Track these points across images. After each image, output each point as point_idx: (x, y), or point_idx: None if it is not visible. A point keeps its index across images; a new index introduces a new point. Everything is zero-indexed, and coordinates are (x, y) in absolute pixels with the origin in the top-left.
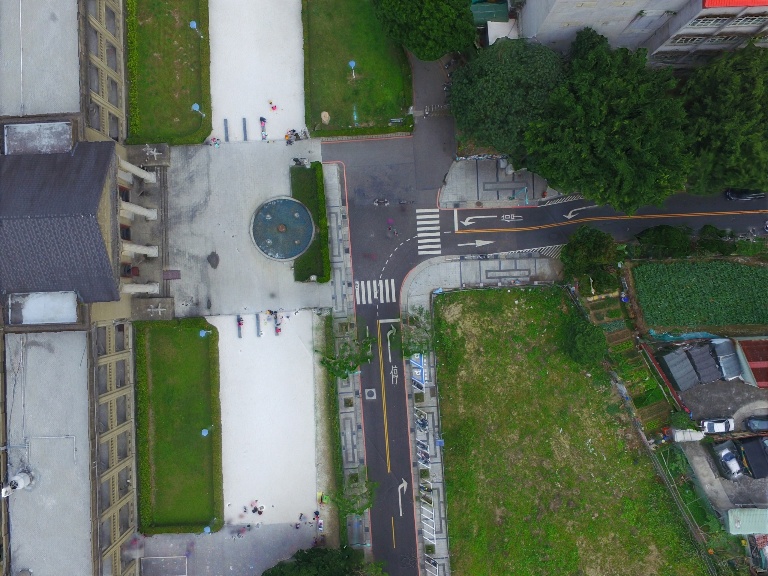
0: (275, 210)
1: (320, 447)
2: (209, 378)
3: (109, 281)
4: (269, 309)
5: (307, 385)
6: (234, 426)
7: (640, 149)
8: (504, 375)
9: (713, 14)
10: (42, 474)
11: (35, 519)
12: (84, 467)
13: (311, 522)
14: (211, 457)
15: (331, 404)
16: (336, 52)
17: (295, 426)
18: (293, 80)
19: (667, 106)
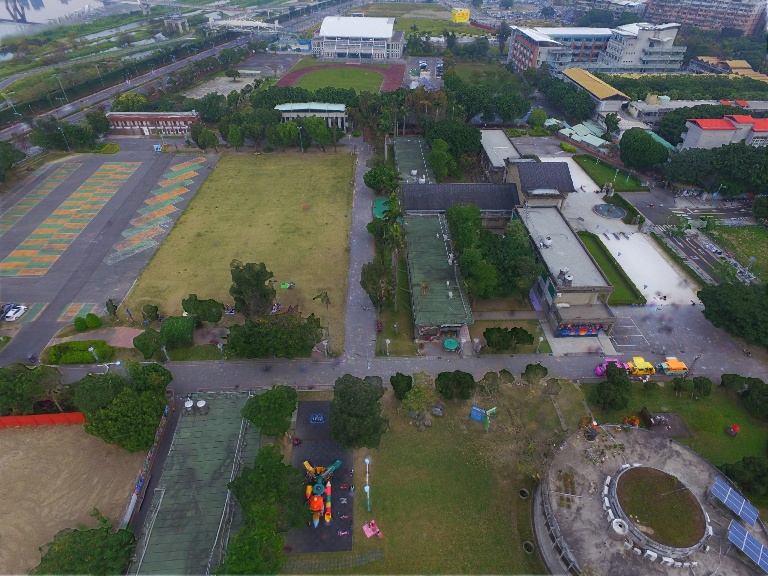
0: (602, 207)
1: (681, 275)
2: (601, 252)
3: (571, 184)
4: (619, 231)
5: (656, 255)
6: (625, 268)
7: (763, 159)
8: (762, 251)
9: (759, 136)
10: (554, 245)
11: (557, 259)
12: (575, 243)
13: (700, 304)
14: (619, 278)
15: (676, 257)
16: (602, 176)
17: (660, 268)
18: (588, 181)
19: (764, 148)
